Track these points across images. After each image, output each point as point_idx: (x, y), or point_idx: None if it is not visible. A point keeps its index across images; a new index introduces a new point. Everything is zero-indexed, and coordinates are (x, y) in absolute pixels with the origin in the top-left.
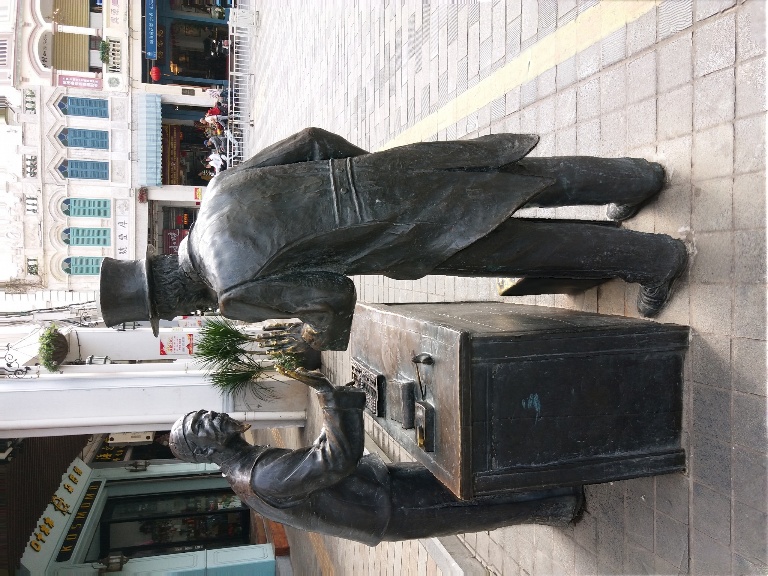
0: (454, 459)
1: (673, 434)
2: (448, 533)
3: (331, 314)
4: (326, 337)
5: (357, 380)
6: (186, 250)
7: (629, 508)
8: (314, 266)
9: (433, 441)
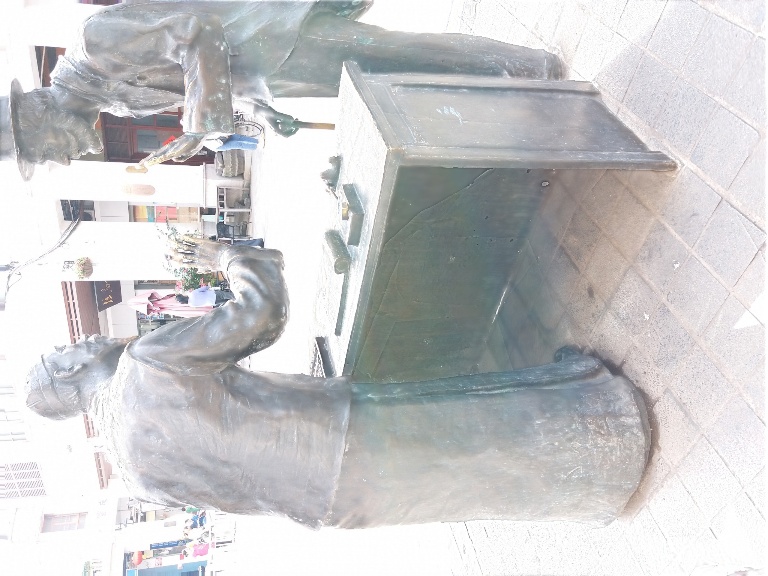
0: (372, 141)
1: (638, 147)
2: (458, 446)
3: (196, 19)
4: (202, 86)
5: None
6: None
7: (676, 303)
8: None
9: (360, 206)
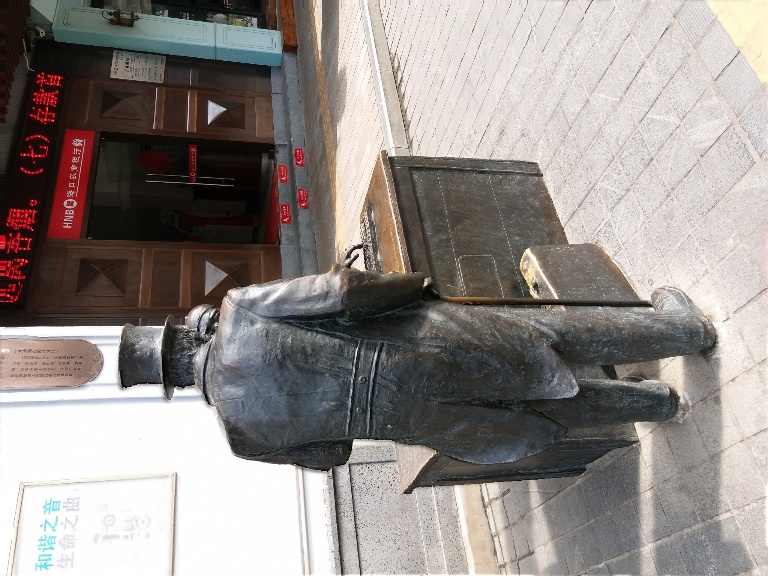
0: (406, 475)
1: (584, 463)
2: None
3: None
4: None
5: (366, 234)
6: (202, 389)
7: None
8: None
9: None
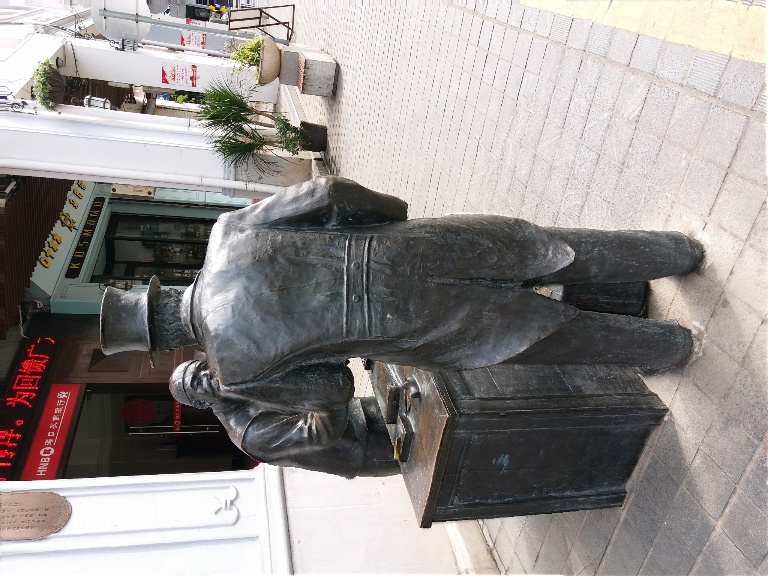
0: (421, 495)
1: (621, 480)
2: None
3: None
4: None
5: None
6: (189, 319)
7: None
8: (316, 359)
9: (408, 455)
